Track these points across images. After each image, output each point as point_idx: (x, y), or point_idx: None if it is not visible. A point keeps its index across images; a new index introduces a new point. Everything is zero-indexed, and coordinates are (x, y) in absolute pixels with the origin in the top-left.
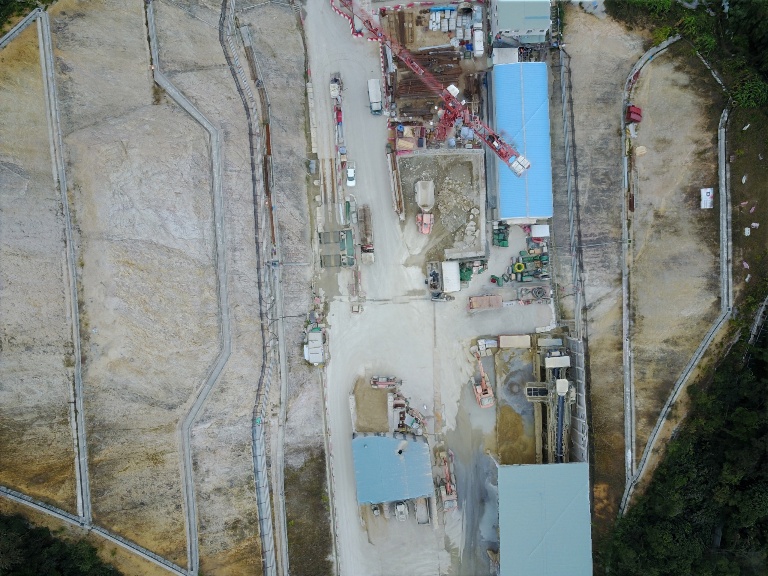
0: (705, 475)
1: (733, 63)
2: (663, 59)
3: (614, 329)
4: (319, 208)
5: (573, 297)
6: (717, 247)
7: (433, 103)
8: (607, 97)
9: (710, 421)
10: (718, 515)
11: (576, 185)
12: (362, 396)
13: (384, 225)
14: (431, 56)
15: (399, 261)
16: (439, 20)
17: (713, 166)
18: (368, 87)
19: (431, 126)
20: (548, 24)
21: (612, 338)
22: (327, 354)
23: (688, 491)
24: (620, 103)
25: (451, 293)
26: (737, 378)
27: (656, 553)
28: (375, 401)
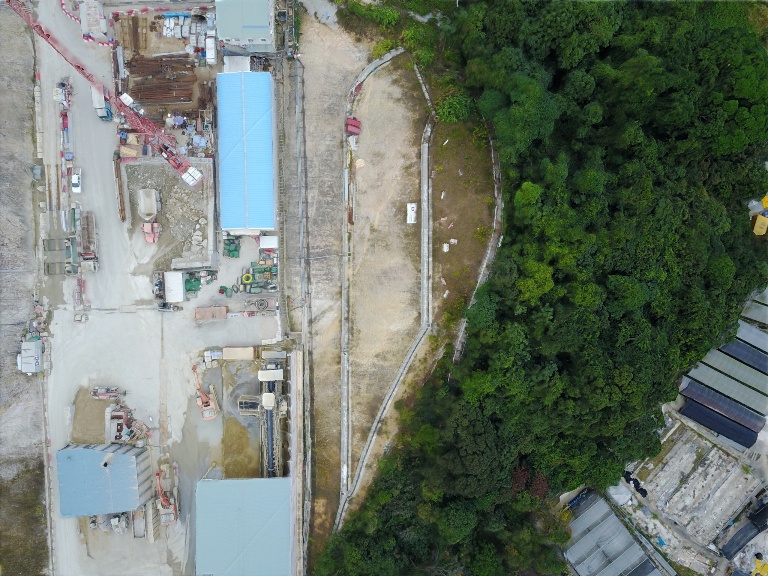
0: (412, 491)
1: (443, 78)
2: (384, 72)
3: (334, 343)
4: (42, 214)
5: (301, 309)
6: (419, 262)
7: (165, 110)
8: (333, 108)
9: (414, 437)
10: (430, 531)
11: (306, 196)
12: (83, 407)
13: (111, 233)
14: (163, 63)
15: (126, 270)
16: (173, 26)
17: (417, 181)
18: (91, 93)
19: (162, 133)
20: (267, 33)
21: (333, 352)
22: (47, 363)
23: (393, 507)
24: (343, 115)
25: (178, 303)
26: (433, 394)
27: (350, 570)
28: (95, 412)
